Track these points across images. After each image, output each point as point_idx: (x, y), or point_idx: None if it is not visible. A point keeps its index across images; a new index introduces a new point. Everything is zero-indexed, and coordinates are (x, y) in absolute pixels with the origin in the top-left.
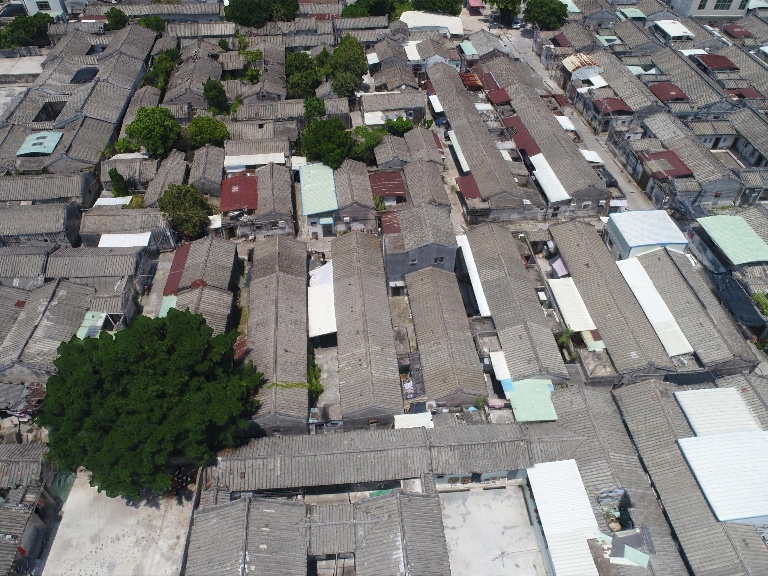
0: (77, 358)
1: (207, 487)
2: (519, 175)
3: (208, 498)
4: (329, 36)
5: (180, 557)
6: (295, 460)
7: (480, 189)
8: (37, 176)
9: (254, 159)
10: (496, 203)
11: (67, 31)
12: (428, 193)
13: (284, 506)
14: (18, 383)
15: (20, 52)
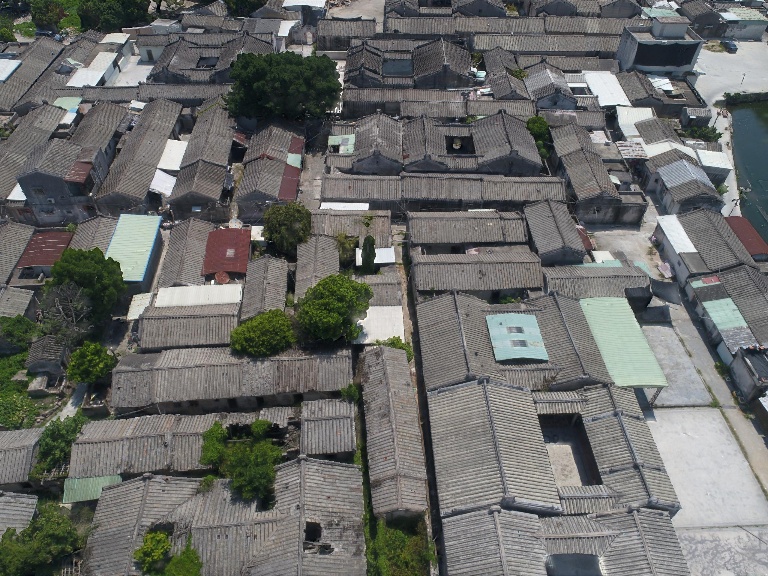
0: None
1: None
2: None
3: None
4: None
5: None
6: None
7: None
8: (474, 269)
9: (200, 292)
10: None
11: None
12: (7, 232)
13: None
14: None
15: None
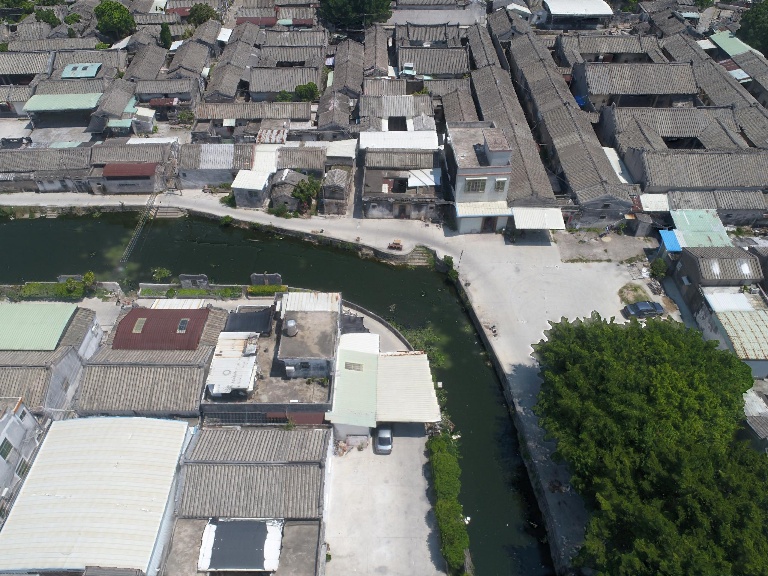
0: None
1: None
2: None
3: (392, 4)
4: None
5: None
6: None
7: None
8: None
9: (159, 5)
10: None
11: None
12: None
13: None
14: None
15: None
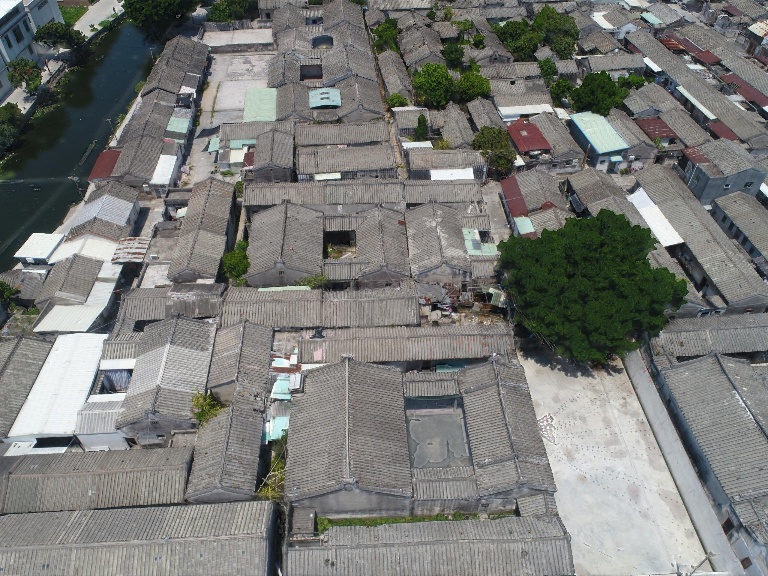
0: (542, 247)
1: (657, 353)
2: (759, 122)
3: (662, 361)
4: (521, 8)
5: (635, 412)
6: (720, 332)
7: (737, 133)
8: None
9: (526, 109)
10: (756, 144)
11: (276, 6)
12: (699, 135)
13: (737, 363)
14: (434, 283)
15: (233, 25)
